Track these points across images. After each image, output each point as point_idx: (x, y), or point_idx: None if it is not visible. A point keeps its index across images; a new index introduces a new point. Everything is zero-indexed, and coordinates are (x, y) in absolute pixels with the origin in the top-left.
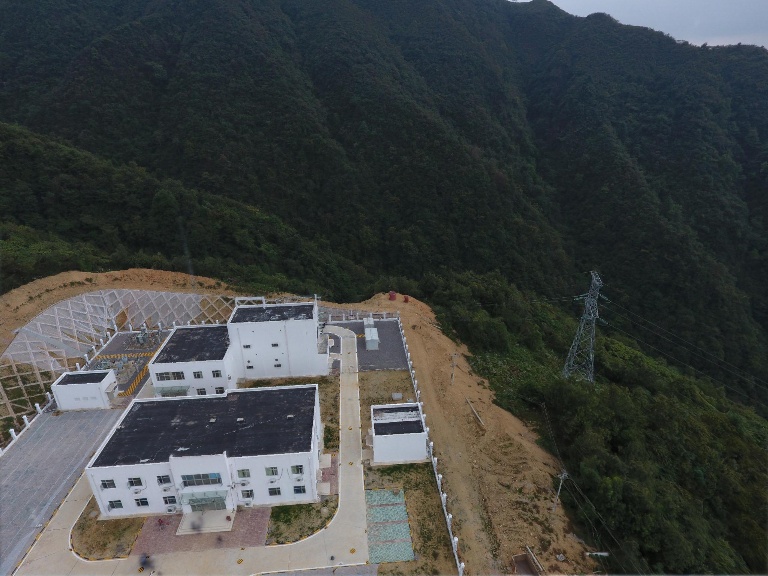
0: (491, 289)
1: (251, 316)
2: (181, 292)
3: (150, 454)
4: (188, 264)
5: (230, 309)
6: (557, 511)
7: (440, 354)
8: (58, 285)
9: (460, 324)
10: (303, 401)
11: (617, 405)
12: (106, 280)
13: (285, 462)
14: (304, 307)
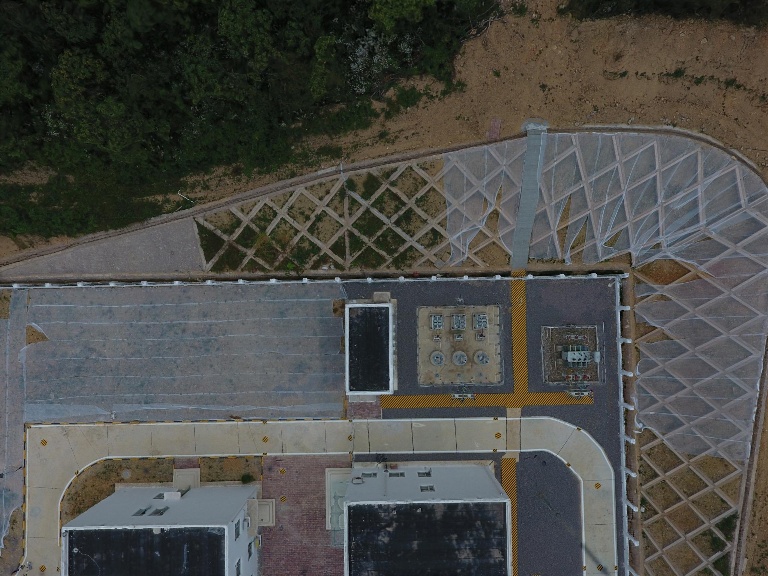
0: None
1: None
2: None
3: None
4: None
5: (692, 530)
6: None
7: None
8: None
9: None
10: None
11: None
12: None
13: None
14: None
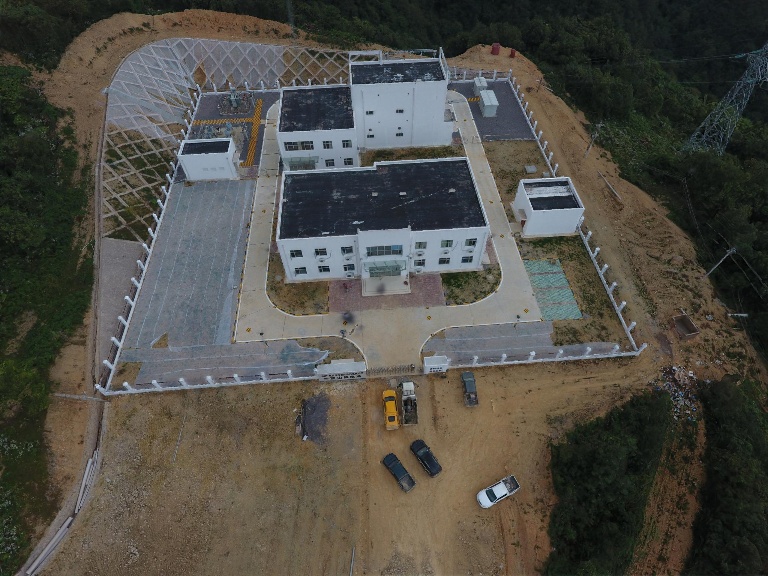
0: (604, 40)
1: (371, 75)
2: (257, 42)
3: (328, 227)
4: (255, 3)
5: (318, 65)
6: (705, 280)
7: (563, 122)
8: (117, 32)
9: (576, 86)
10: (457, 175)
11: (767, 181)
12: (165, 25)
13: (462, 236)
14: (426, 64)
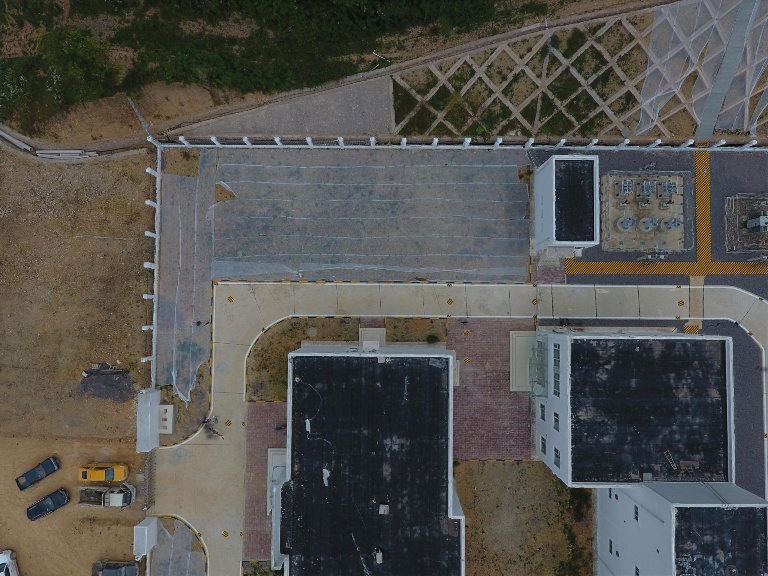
0: None
1: (723, 546)
2: None
3: (320, 430)
4: None
5: None
6: None
7: None
8: None
9: None
10: None
11: None
12: None
13: None
14: None
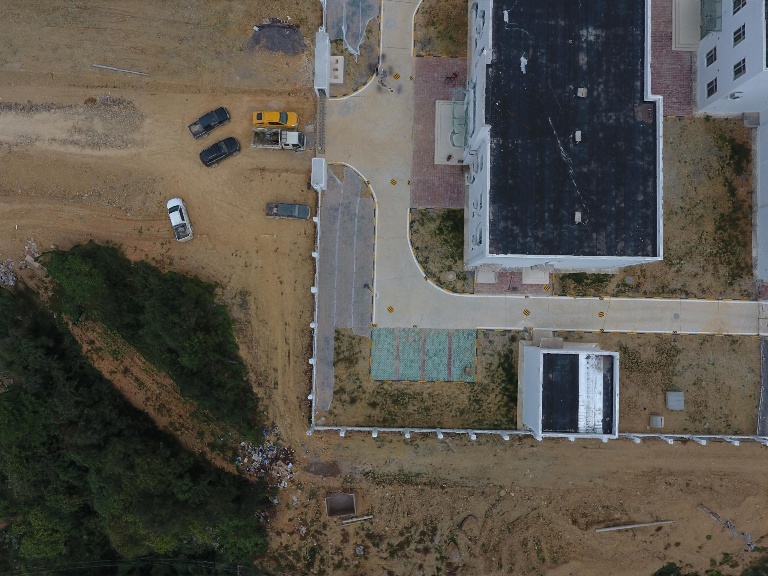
0: None
1: None
2: None
3: (518, 20)
4: None
5: None
6: None
7: None
8: None
9: None
10: (621, 236)
11: None
12: None
13: (484, 218)
14: None
